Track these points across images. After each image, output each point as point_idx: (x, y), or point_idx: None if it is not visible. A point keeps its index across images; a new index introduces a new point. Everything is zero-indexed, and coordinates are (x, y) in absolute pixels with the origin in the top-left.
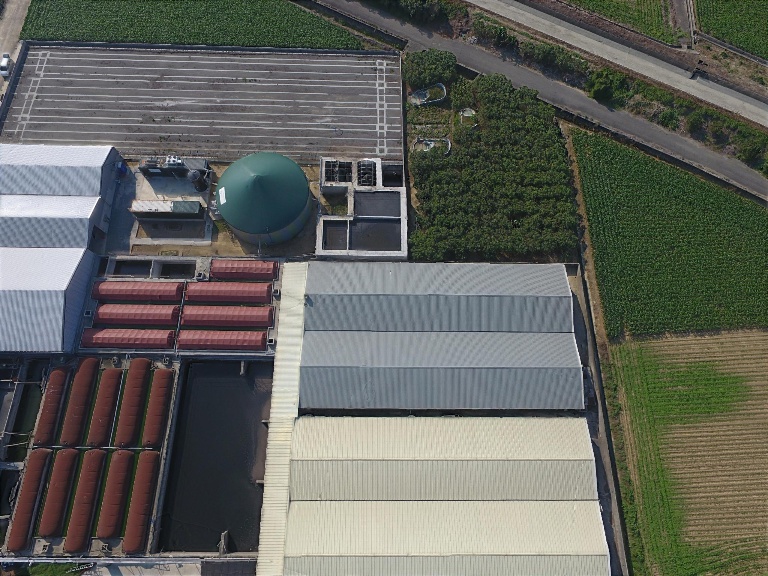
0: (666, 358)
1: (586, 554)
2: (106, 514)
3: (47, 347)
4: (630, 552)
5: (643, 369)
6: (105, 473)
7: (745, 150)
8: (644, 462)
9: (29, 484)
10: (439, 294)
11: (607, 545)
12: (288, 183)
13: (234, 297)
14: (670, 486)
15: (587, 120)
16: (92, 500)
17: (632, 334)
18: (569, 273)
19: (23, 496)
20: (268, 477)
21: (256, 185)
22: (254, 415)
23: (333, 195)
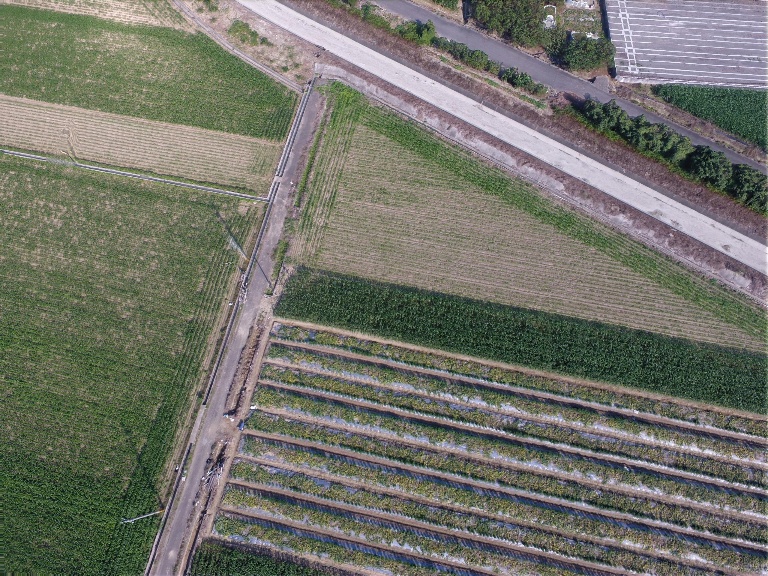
0: None
1: None
2: None
3: None
4: None
5: None
6: None
7: None
8: None
9: None
10: None
11: None
12: None
13: None
14: None
15: (442, 15)
16: None
17: None
18: None
19: None
20: None
21: None
22: None
23: None
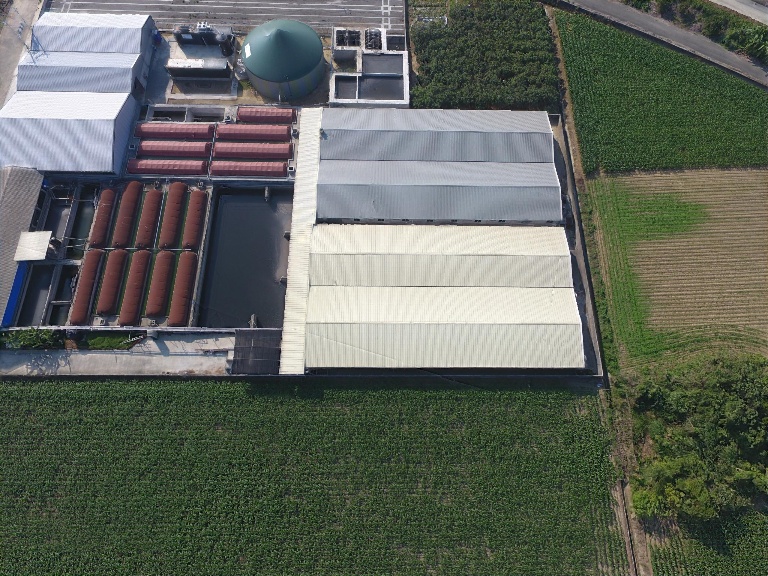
0: (635, 190)
1: (562, 323)
2: (154, 296)
3: (99, 167)
4: (601, 336)
5: (615, 198)
6: (151, 269)
7: (709, 25)
8: (614, 268)
9: (87, 273)
10: (437, 130)
11: (580, 318)
12: (305, 40)
13: (259, 135)
14: (637, 286)
15: (569, 3)
16: (141, 287)
17: (606, 171)
18: (551, 124)
19: (83, 282)
20: (291, 268)
21: (278, 37)
22: (277, 231)
23: (343, 61)
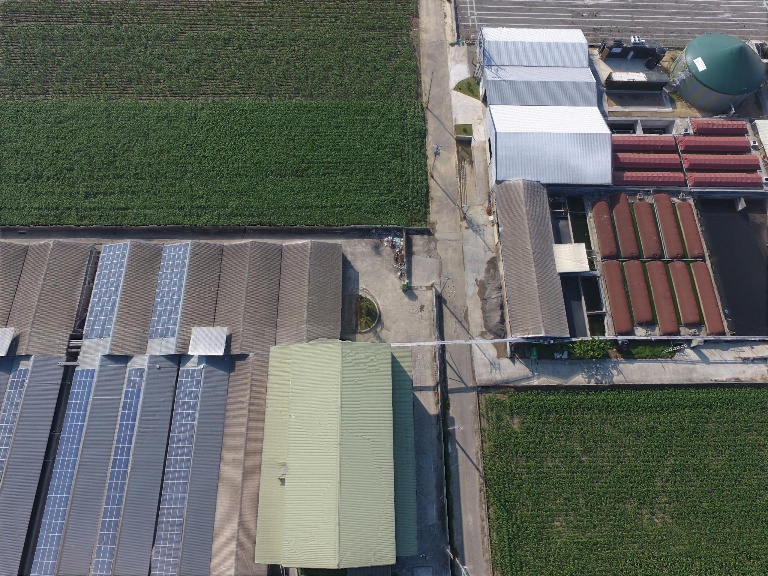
0: None
1: None
2: (691, 305)
3: (599, 180)
4: None
5: None
6: (668, 279)
7: None
8: None
9: (620, 284)
10: None
11: None
12: (754, 53)
13: (723, 147)
14: None
15: None
16: None
17: None
18: None
19: (619, 292)
20: None
21: (742, 51)
22: (758, 241)
23: None
